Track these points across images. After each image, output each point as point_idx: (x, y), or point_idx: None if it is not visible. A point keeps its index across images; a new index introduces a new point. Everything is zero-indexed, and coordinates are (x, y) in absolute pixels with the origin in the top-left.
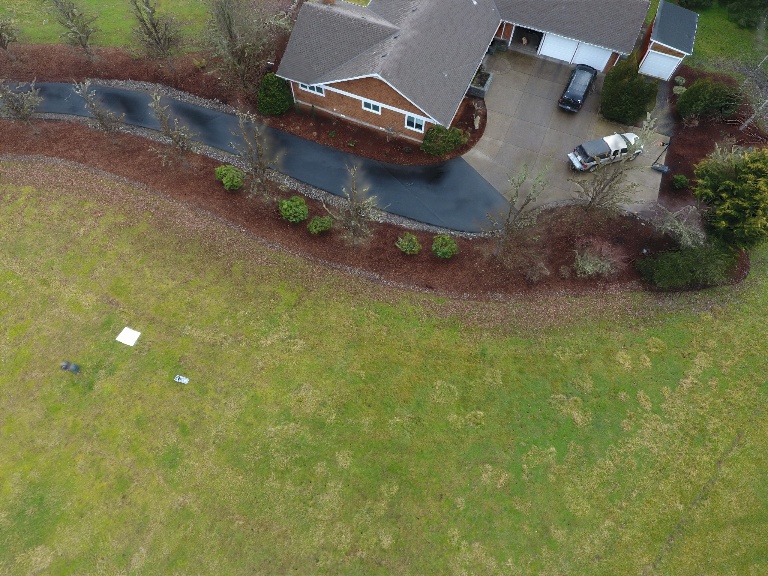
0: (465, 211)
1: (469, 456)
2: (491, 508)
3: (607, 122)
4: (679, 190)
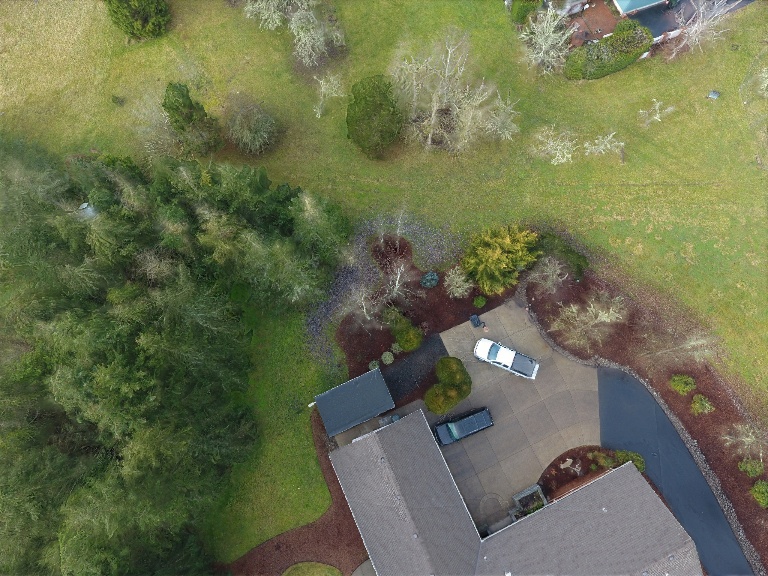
0: (634, 401)
1: (759, 274)
2: (766, 250)
3: None
4: (487, 298)
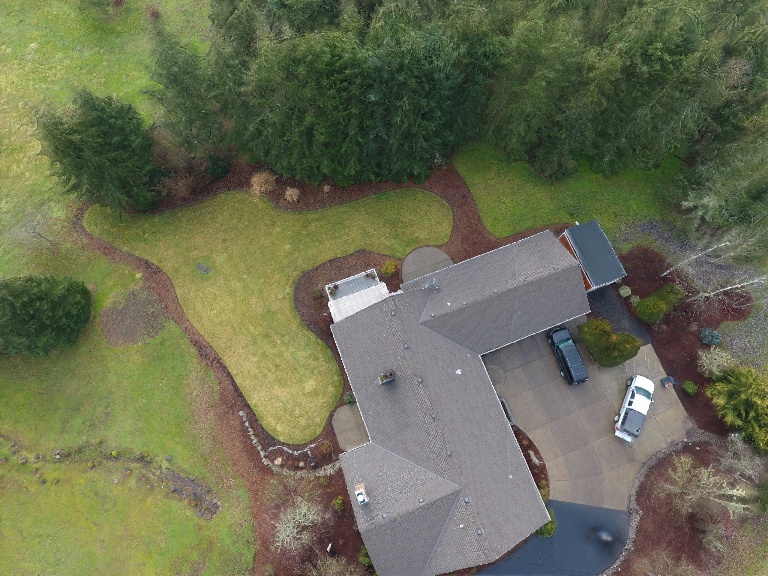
0: (595, 548)
1: None
2: None
3: (606, 367)
4: (694, 396)
